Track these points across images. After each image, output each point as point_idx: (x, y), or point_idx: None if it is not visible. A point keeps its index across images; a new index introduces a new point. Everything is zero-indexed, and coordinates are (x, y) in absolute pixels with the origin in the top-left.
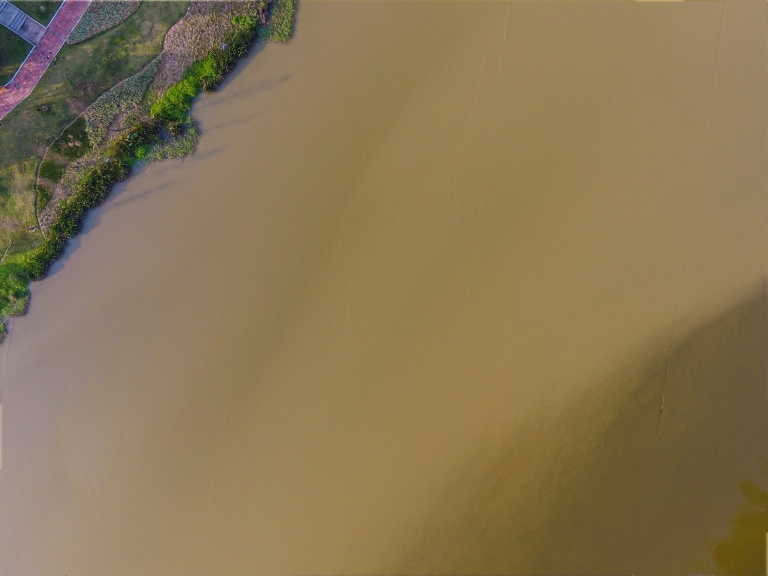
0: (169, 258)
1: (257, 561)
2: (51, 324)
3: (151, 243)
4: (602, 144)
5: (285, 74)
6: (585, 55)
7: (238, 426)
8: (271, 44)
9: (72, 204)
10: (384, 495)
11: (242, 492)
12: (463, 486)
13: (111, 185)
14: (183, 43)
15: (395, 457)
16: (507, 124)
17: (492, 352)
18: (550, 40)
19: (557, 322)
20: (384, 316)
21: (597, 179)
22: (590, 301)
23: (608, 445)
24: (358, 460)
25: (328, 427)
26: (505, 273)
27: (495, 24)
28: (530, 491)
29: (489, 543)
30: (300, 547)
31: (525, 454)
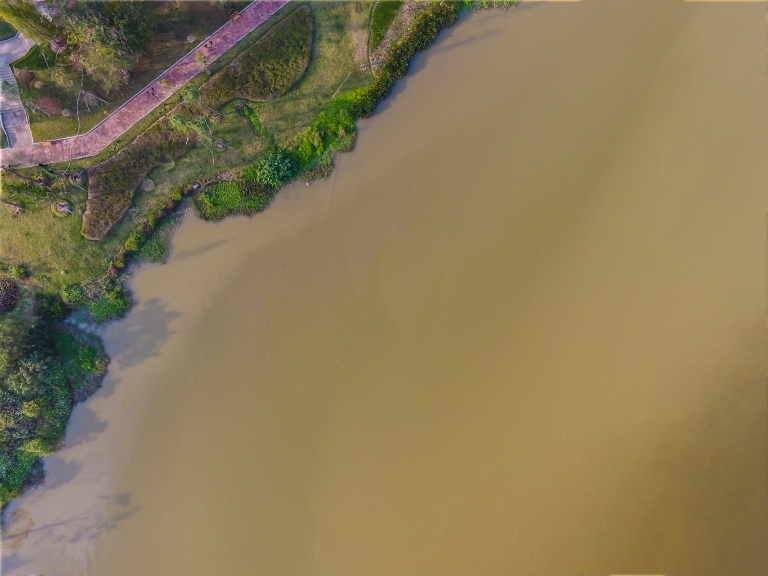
0: (492, 103)
1: (570, 402)
2: (375, 161)
3: (475, 87)
4: None
5: None
6: None
7: (555, 269)
8: None
9: (404, 45)
10: (695, 343)
11: (557, 333)
12: None
13: (440, 29)
14: None
15: (707, 306)
16: None
17: None
18: None
19: None
20: (699, 168)
21: None
22: None
23: None
24: (671, 307)
25: (643, 274)
26: None
27: None
28: None
29: None
30: (613, 390)
31: None
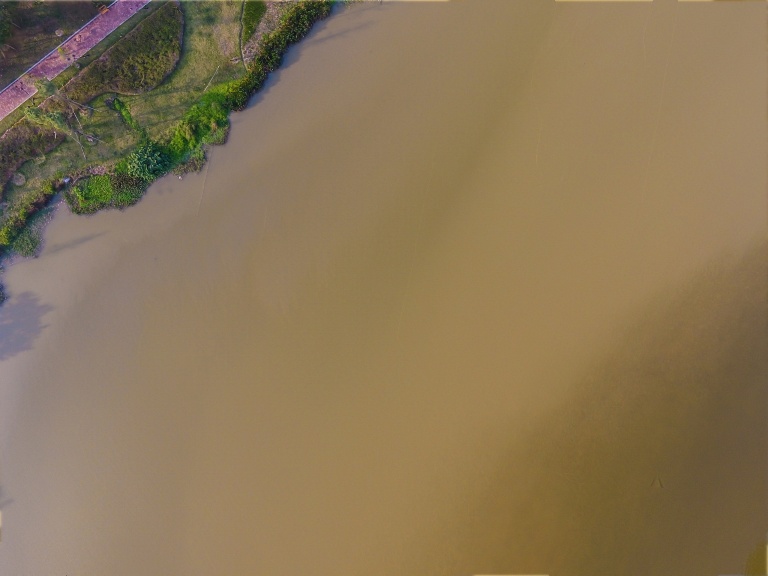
0: (365, 95)
1: (443, 393)
2: (248, 154)
3: (349, 80)
4: None
5: None
6: None
7: (428, 260)
8: None
9: (276, 37)
10: (568, 334)
11: (430, 325)
12: (645, 329)
13: (313, 22)
14: None
15: (580, 297)
16: None
17: (677, 198)
18: None
19: (740, 172)
20: (572, 159)
21: None
22: None
23: None
24: (544, 298)
25: (516, 265)
26: (688, 125)
27: None
28: (710, 336)
29: (669, 385)
30: (486, 381)
31: (706, 300)
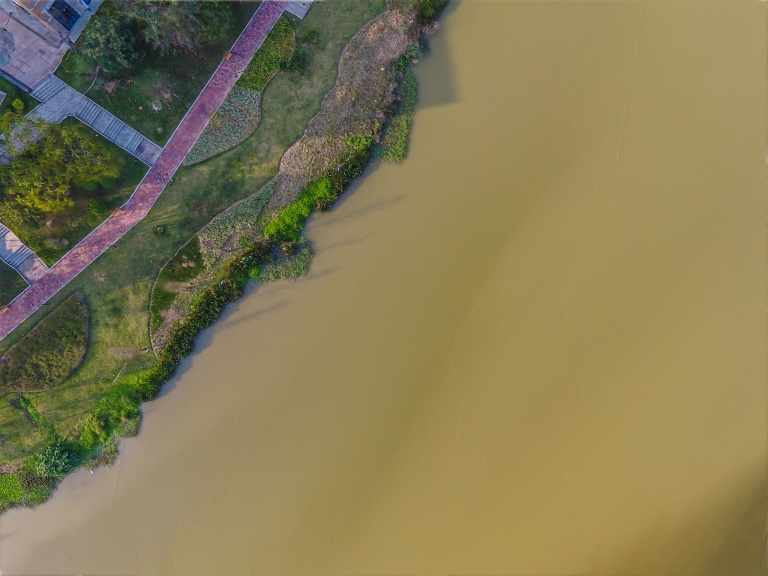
0: (281, 379)
1: None
2: (162, 444)
3: (263, 364)
4: (712, 267)
5: (398, 194)
6: (697, 178)
7: (349, 548)
8: (385, 164)
9: (185, 325)
10: None
11: None
12: None
13: (224, 306)
14: (299, 164)
15: None
16: (619, 247)
17: (602, 475)
18: (662, 163)
19: (666, 445)
20: (495, 438)
21: (707, 302)
22: (699, 424)
23: (715, 568)
24: None
25: (439, 549)
26: (614, 394)
27: (608, 146)
28: None
29: None
30: None
31: (633, 575)
